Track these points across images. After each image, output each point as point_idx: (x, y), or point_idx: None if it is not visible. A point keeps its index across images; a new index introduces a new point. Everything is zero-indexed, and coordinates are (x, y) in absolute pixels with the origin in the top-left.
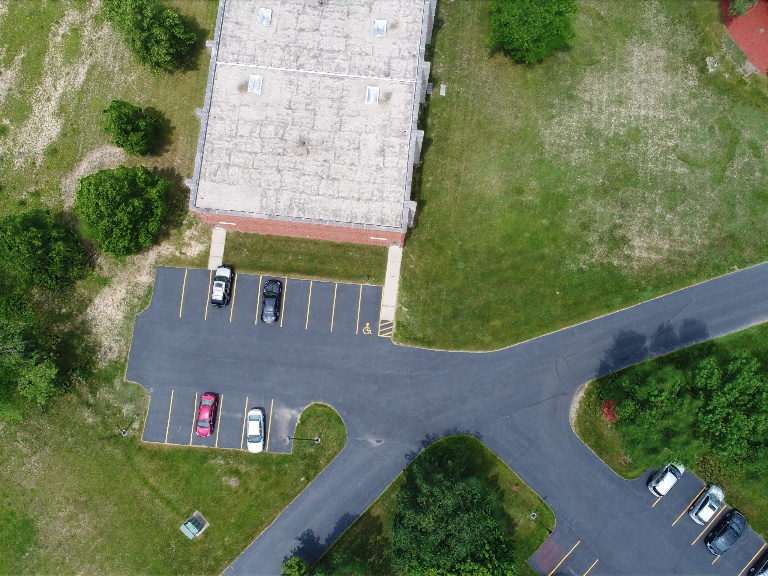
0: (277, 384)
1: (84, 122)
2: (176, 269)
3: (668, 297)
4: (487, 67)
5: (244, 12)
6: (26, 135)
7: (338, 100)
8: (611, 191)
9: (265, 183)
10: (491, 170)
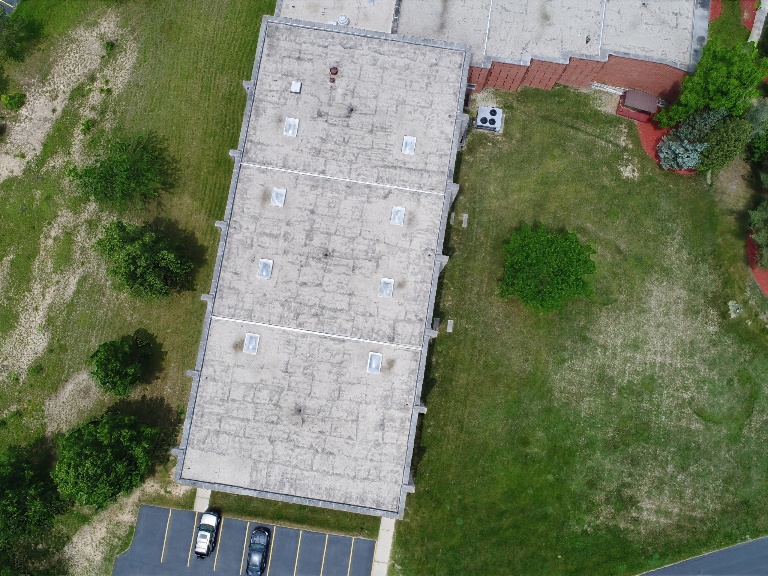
0: None
1: (72, 339)
2: (160, 509)
3: (675, 567)
4: (498, 302)
5: (244, 261)
6: (11, 346)
7: (338, 365)
8: (621, 446)
9: (256, 454)
10: (496, 417)
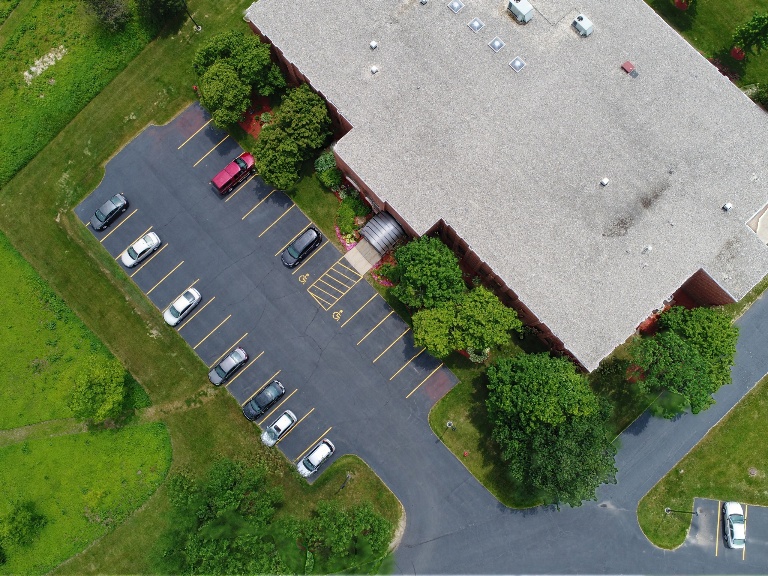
0: (713, 573)
1: None
2: None
3: None
4: None
5: None
6: None
7: None
8: None
9: None
10: None
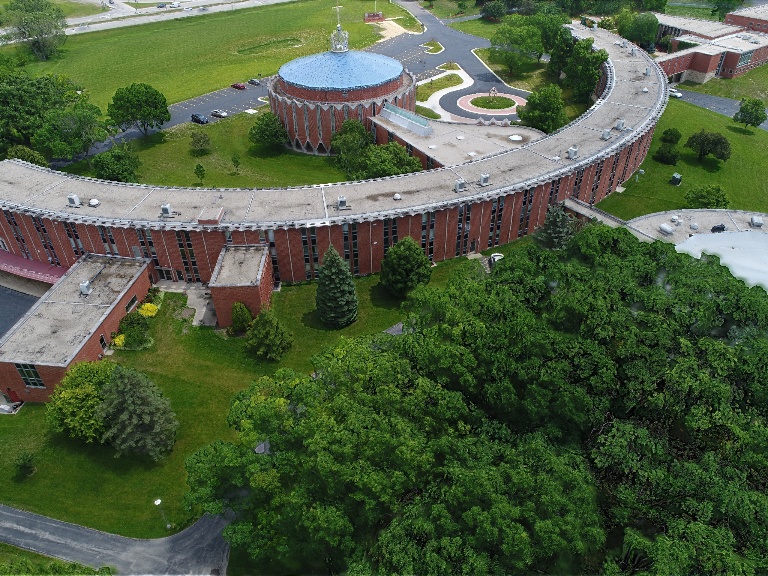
0: None
1: None
2: None
3: (713, 8)
4: None
5: None
6: None
7: None
8: None
9: None
10: None
